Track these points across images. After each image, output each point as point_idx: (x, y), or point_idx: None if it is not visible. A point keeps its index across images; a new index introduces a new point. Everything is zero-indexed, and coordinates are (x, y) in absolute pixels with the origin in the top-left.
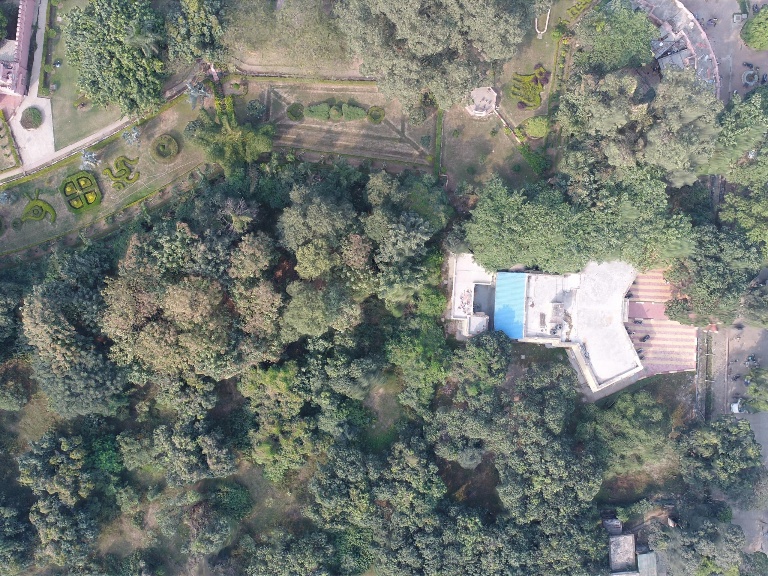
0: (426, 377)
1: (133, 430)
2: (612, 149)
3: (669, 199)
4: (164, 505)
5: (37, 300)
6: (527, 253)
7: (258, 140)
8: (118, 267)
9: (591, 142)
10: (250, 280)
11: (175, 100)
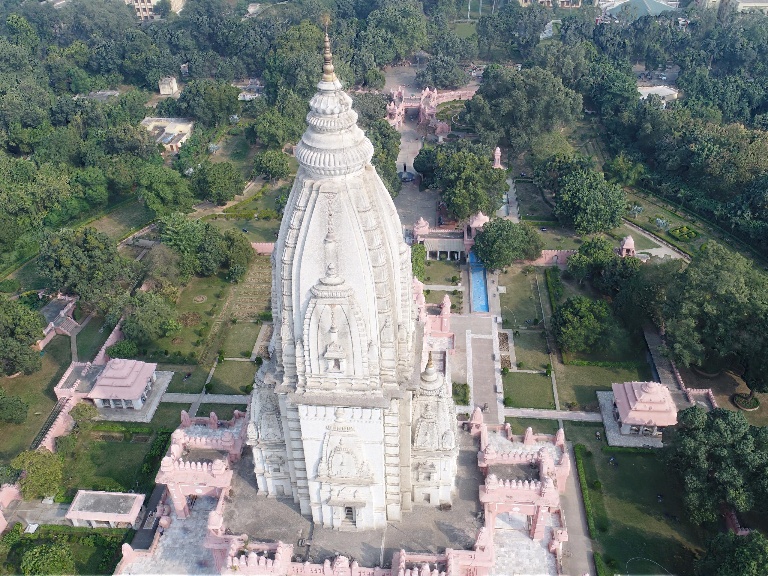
0: None
1: None
2: (582, 61)
3: None
4: None
5: None
6: None
7: None
8: None
9: None
10: None
11: None
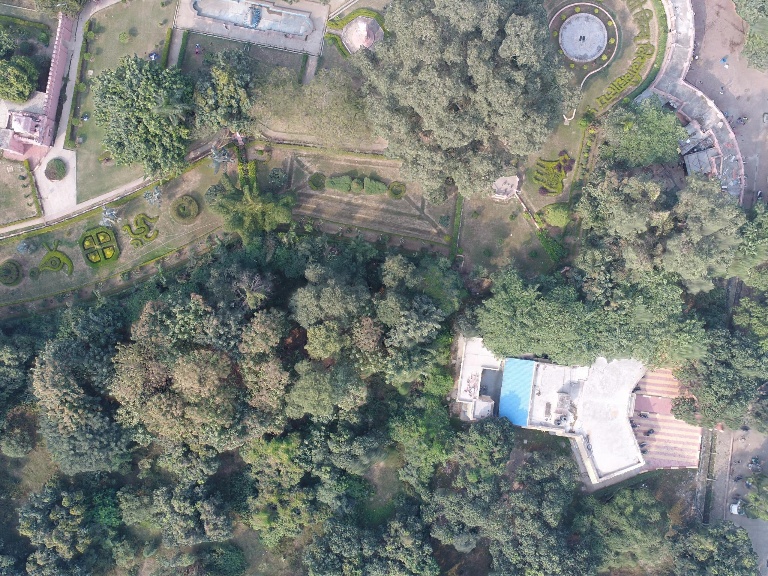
0: (427, 457)
1: (134, 485)
2: (630, 254)
3: (684, 295)
4: (159, 564)
5: (49, 361)
6: (537, 346)
7: (278, 211)
8: (130, 326)
9: (610, 240)
10: (260, 353)
11: (199, 162)
